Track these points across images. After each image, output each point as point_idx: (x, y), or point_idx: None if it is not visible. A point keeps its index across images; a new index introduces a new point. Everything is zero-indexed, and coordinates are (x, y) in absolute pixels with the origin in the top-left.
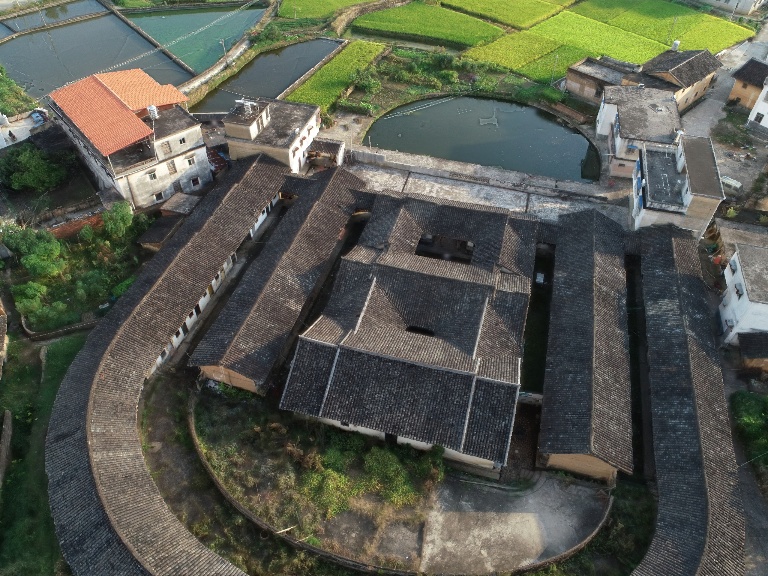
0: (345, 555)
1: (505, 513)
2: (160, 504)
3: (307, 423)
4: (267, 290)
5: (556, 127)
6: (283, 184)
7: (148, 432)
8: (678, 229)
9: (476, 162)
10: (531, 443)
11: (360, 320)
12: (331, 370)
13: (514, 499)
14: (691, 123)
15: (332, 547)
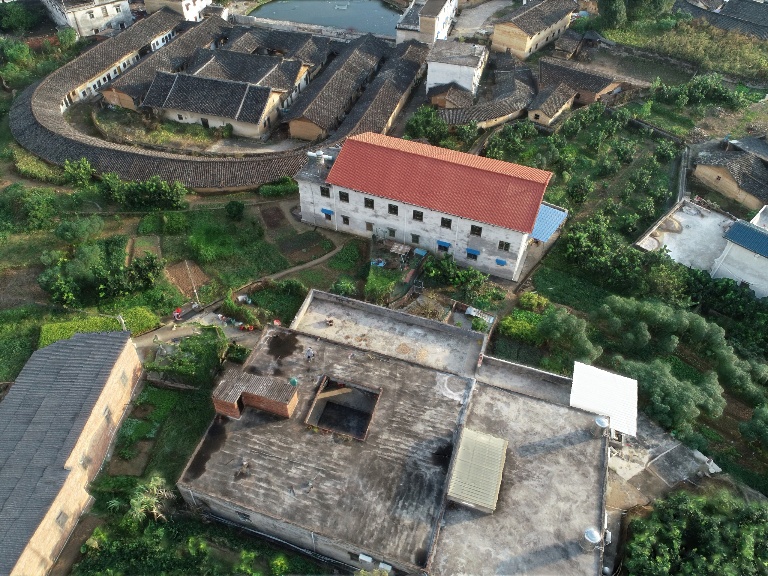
0: None
1: (256, 148)
2: (66, 124)
3: (158, 115)
4: (148, 61)
5: (387, 9)
6: (178, 25)
7: (69, 120)
8: (418, 43)
9: (319, 24)
10: None
11: (198, 71)
12: (172, 86)
13: (265, 146)
14: (484, 8)
15: None
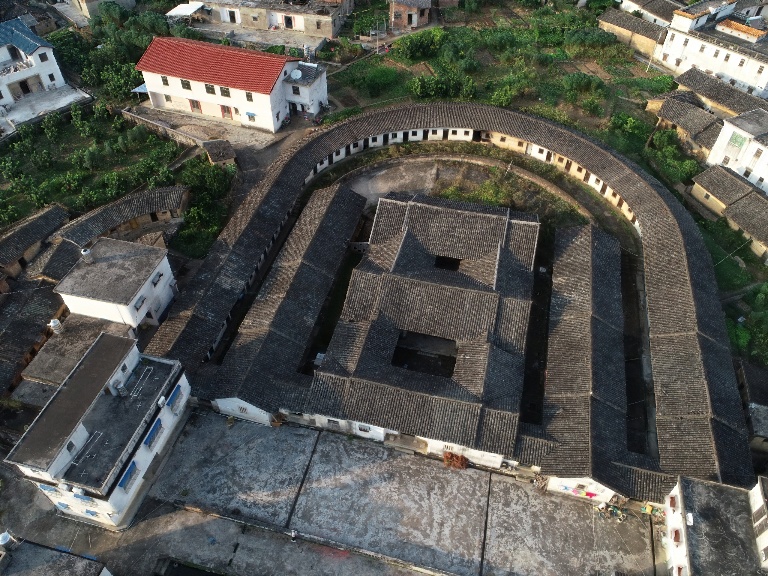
0: (476, 166)
1: None
2: (578, 161)
3: None
4: None
5: None
6: None
7: None
8: None
9: None
10: (364, 233)
11: (498, 254)
12: None
13: None
14: None
15: (483, 167)
